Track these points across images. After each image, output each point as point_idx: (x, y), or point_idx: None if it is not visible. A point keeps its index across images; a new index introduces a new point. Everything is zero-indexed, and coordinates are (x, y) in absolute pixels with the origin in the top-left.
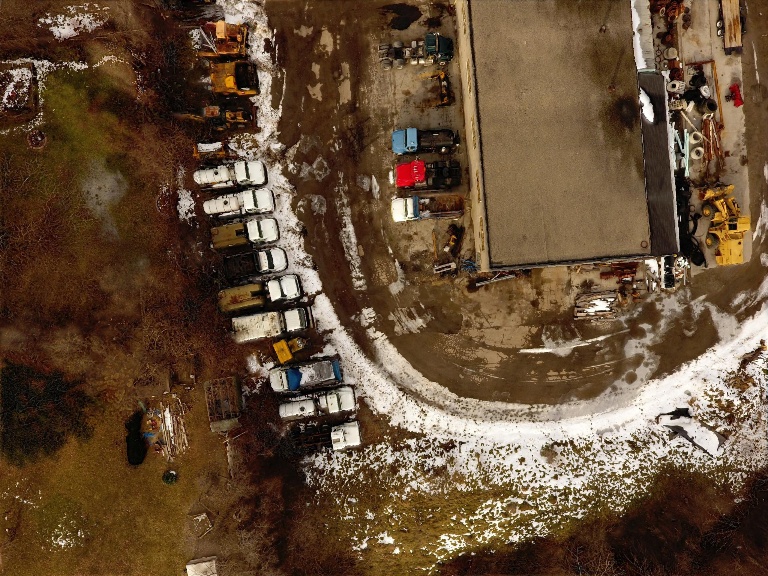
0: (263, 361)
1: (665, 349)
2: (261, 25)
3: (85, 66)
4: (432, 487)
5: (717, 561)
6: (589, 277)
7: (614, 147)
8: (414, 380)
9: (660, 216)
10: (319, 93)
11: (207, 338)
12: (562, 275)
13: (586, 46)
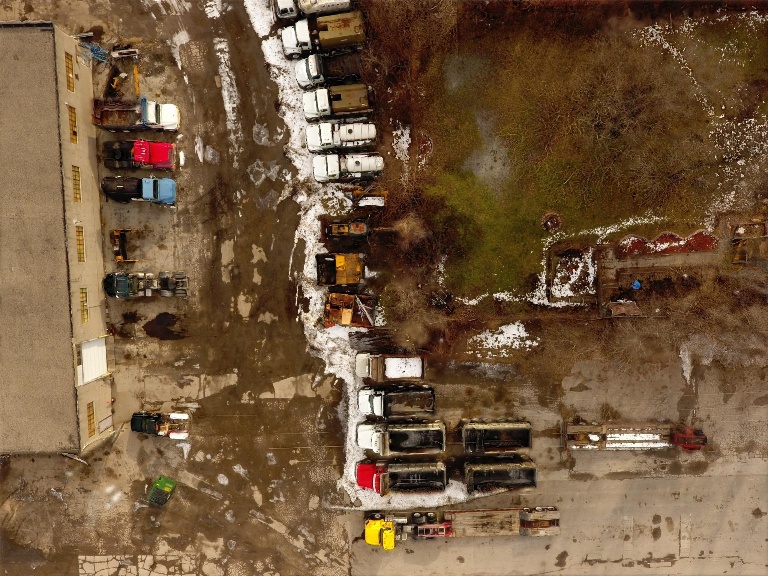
0: None
1: None
2: (310, 324)
3: (496, 296)
4: None
5: None
6: None
7: None
8: None
9: None
10: (255, 253)
11: None
12: None
13: None
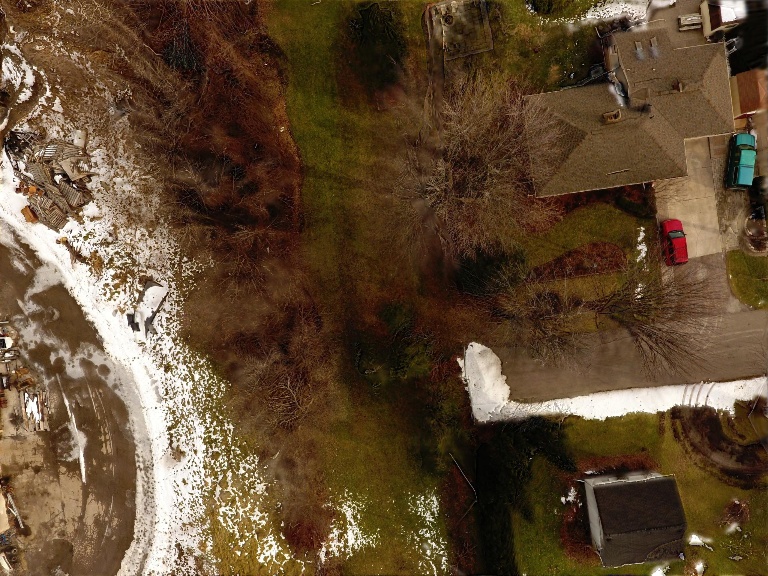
0: None
1: (73, 338)
2: None
3: None
4: (212, 574)
5: (282, 273)
6: (7, 418)
7: None
8: None
9: None
10: None
11: None
12: (7, 445)
13: None
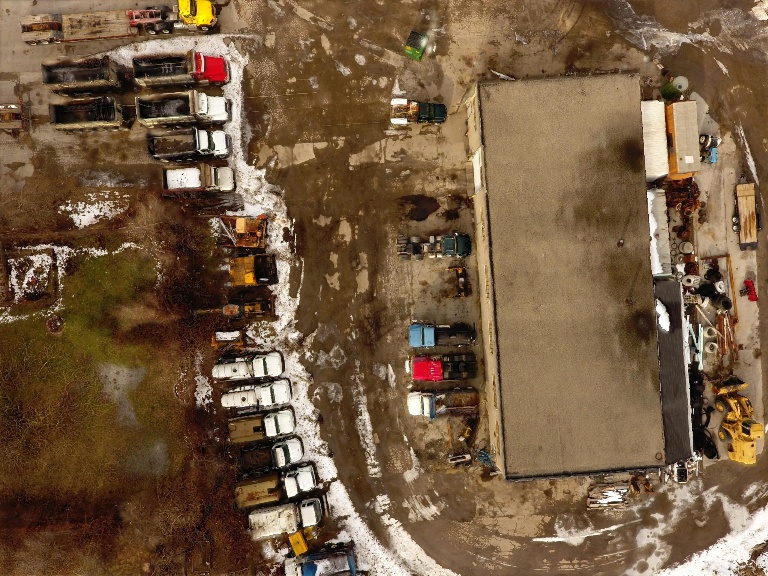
0: (278, 547)
1: (676, 539)
2: (280, 216)
3: (105, 252)
4: None
5: None
6: None
7: (630, 359)
8: (427, 567)
9: (674, 423)
10: (337, 282)
11: (223, 526)
12: None
13: (604, 259)
